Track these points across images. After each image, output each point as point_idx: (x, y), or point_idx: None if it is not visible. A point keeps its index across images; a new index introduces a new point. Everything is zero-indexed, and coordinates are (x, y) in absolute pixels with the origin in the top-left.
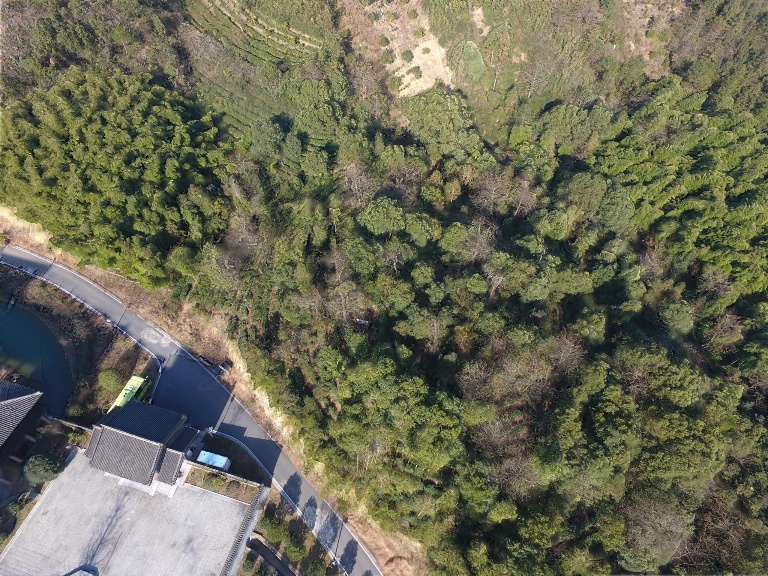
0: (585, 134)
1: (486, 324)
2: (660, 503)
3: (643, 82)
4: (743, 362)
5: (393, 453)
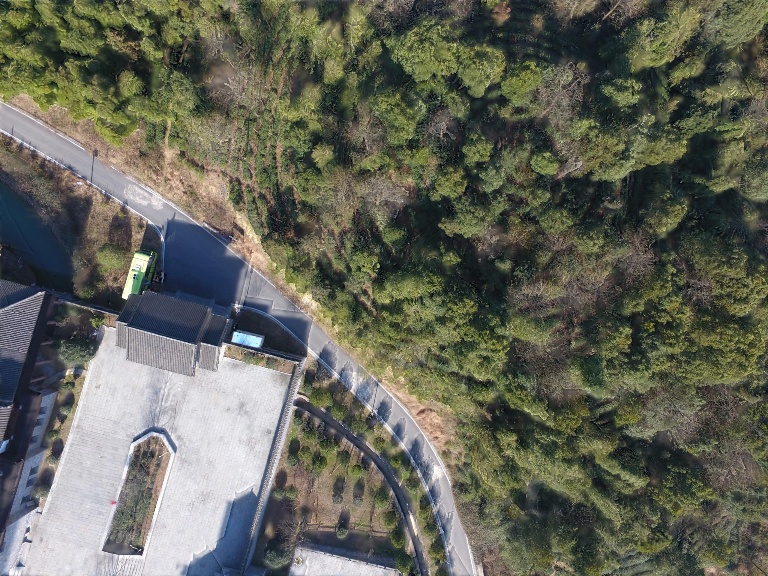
0: None
1: (550, 225)
2: (678, 394)
3: None
4: None
5: None
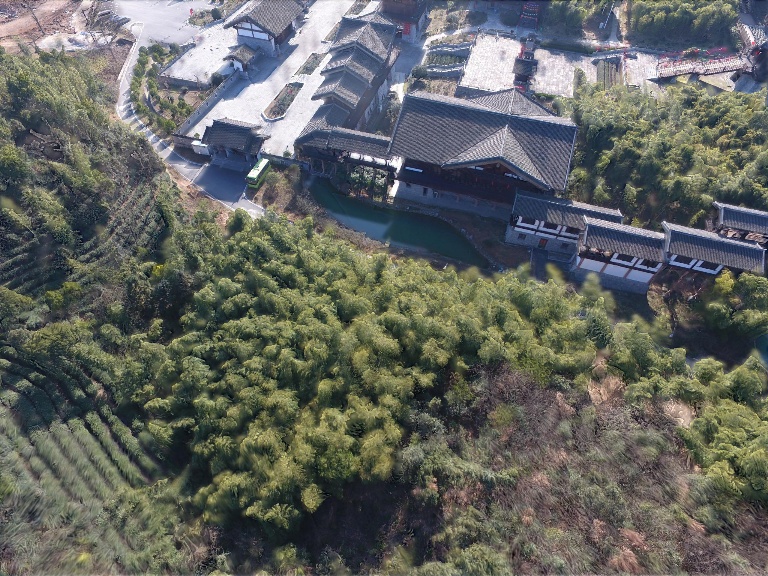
0: None
1: None
2: None
3: None
4: None
5: None
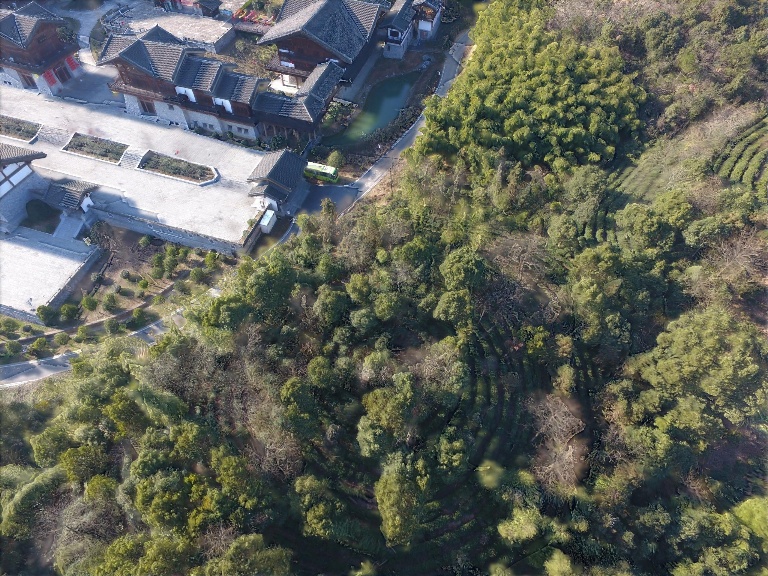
0: None
1: None
2: None
3: None
4: None
5: None
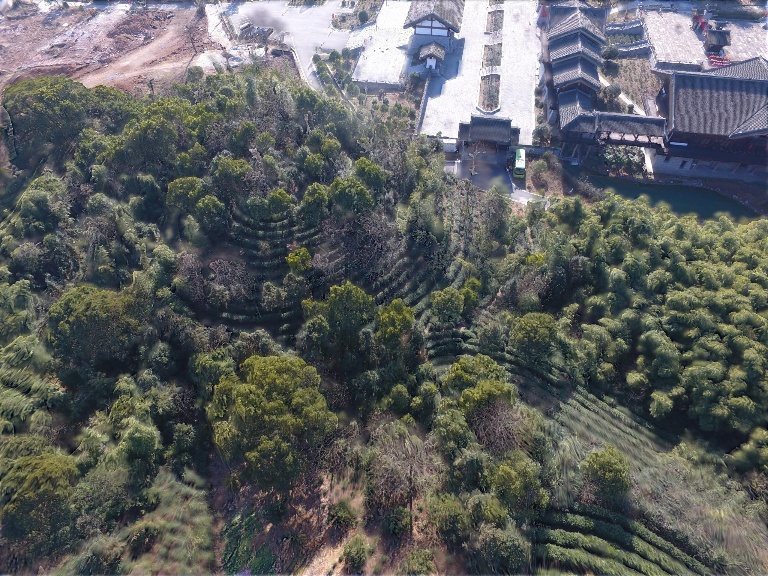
0: None
1: (270, 136)
2: None
3: None
4: None
5: None
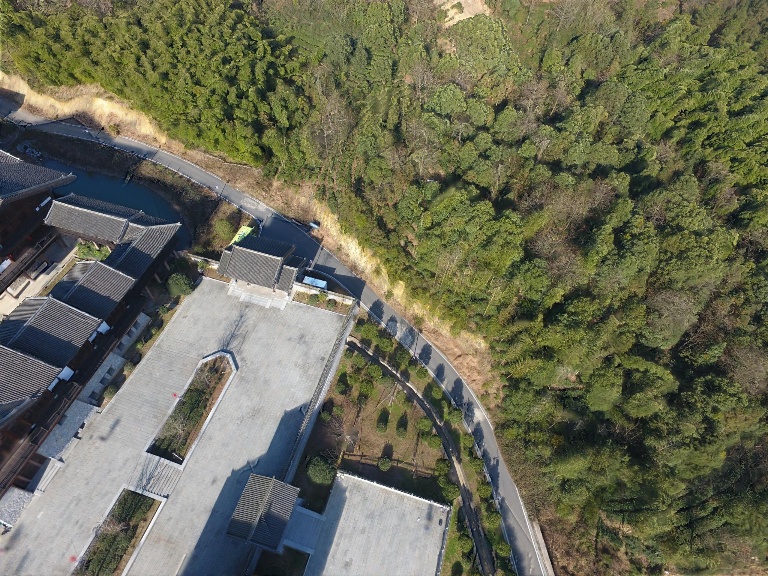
0: (608, 58)
1: (537, 173)
2: None
3: (657, 22)
4: (738, 227)
5: (461, 274)
